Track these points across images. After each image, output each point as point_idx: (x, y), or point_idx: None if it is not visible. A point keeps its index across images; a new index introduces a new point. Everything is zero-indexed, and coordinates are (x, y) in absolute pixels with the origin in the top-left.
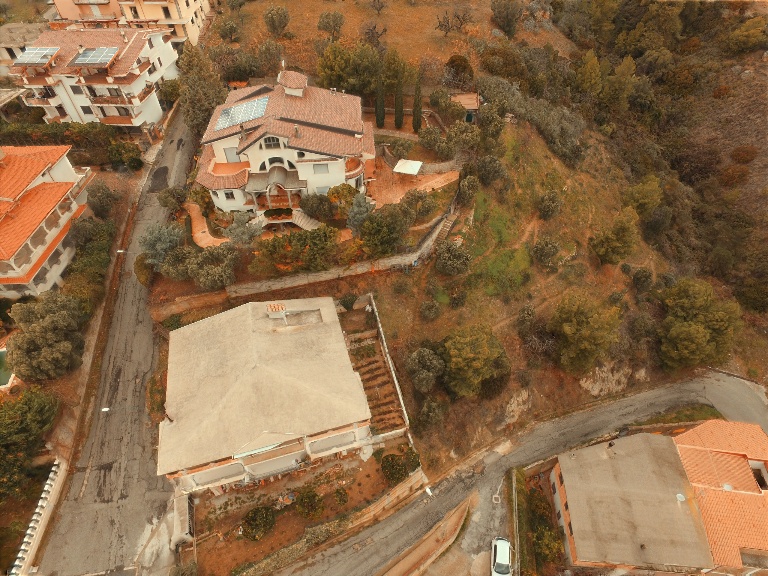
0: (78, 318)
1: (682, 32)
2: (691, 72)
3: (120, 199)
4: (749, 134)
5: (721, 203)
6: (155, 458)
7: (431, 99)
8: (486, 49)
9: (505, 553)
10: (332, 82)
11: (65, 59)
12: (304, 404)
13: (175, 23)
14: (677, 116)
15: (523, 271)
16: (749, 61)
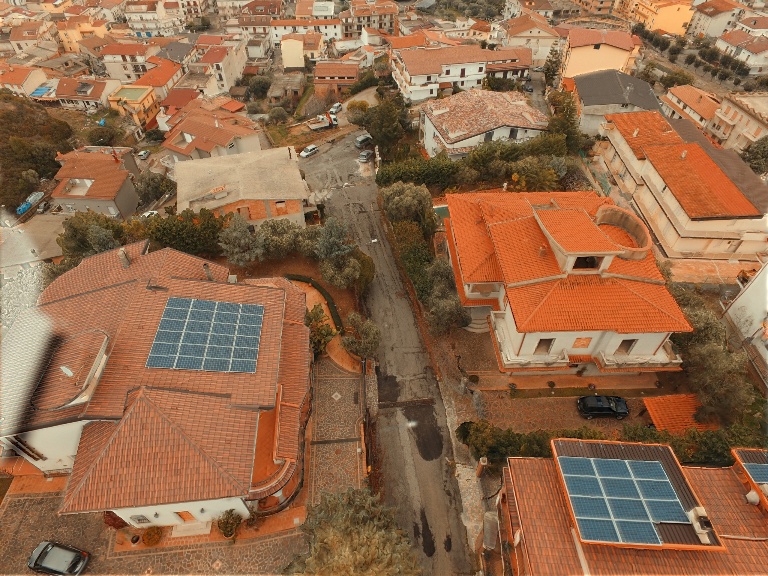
0: None
1: None
2: None
3: None
4: None
5: None
6: (334, 216)
7: None
8: None
9: None
10: None
11: (760, 539)
12: (212, 161)
13: None
14: None
15: None
16: None
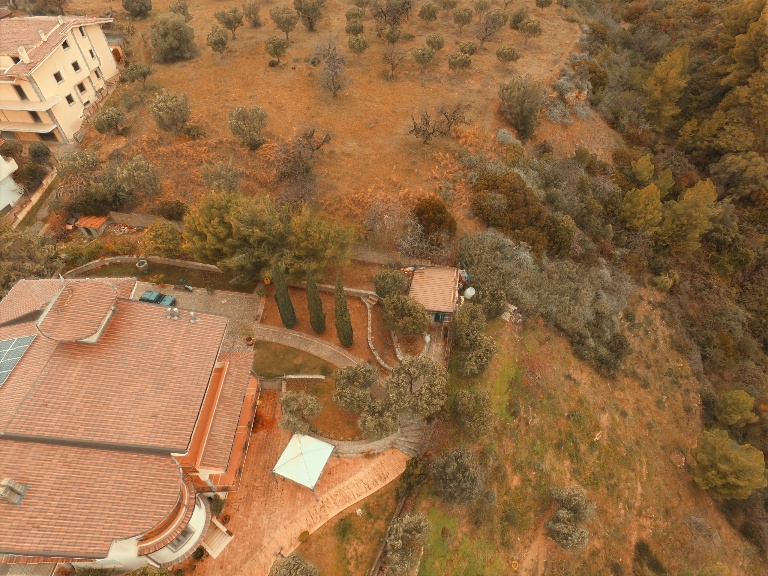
0: None
1: None
2: None
3: None
4: None
5: None
6: None
7: (376, 286)
8: (482, 175)
9: None
10: (207, 255)
11: None
12: None
13: (30, 109)
14: None
15: None
16: None
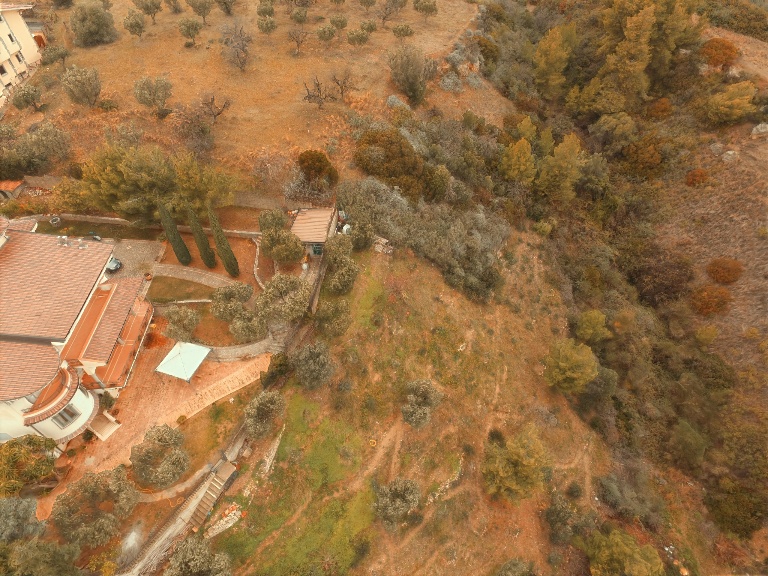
0: None
1: (649, 90)
2: (658, 148)
3: None
4: (732, 242)
5: (692, 343)
6: None
7: (259, 224)
8: (366, 133)
9: None
10: (105, 202)
11: None
12: None
13: None
14: (639, 206)
15: (359, 535)
16: (733, 138)
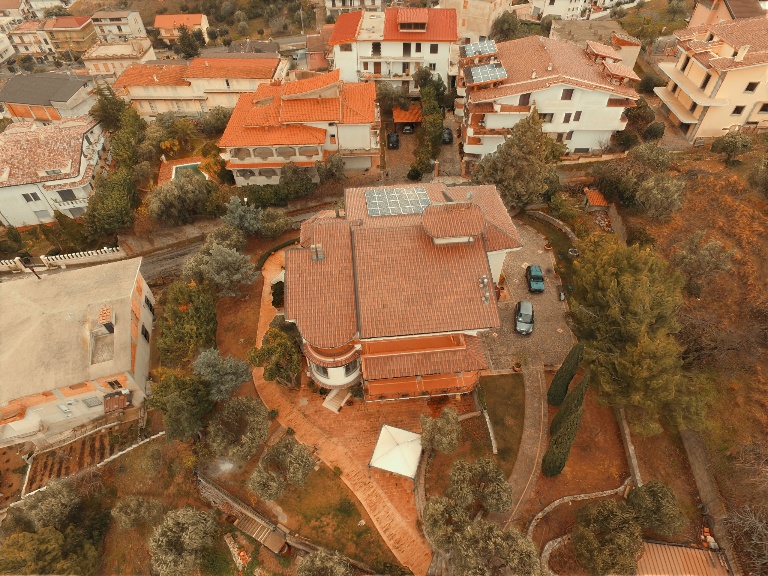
0: (188, 205)
1: None
2: None
3: (343, 181)
4: None
5: None
6: None
7: None
8: None
9: None
10: None
11: None
12: None
13: (693, 98)
14: None
15: None
16: None
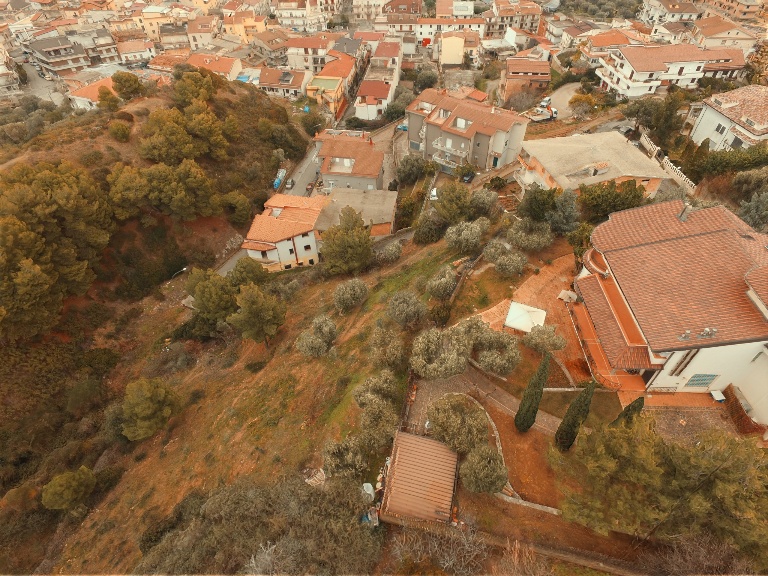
0: None
1: None
2: None
3: None
4: None
5: None
6: None
7: None
8: None
9: (434, 191)
10: None
11: None
12: None
13: None
14: None
15: None
16: None
